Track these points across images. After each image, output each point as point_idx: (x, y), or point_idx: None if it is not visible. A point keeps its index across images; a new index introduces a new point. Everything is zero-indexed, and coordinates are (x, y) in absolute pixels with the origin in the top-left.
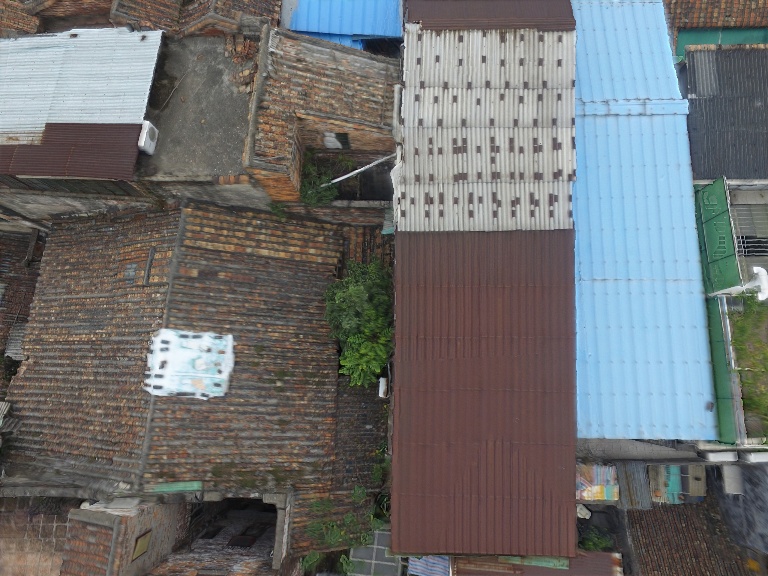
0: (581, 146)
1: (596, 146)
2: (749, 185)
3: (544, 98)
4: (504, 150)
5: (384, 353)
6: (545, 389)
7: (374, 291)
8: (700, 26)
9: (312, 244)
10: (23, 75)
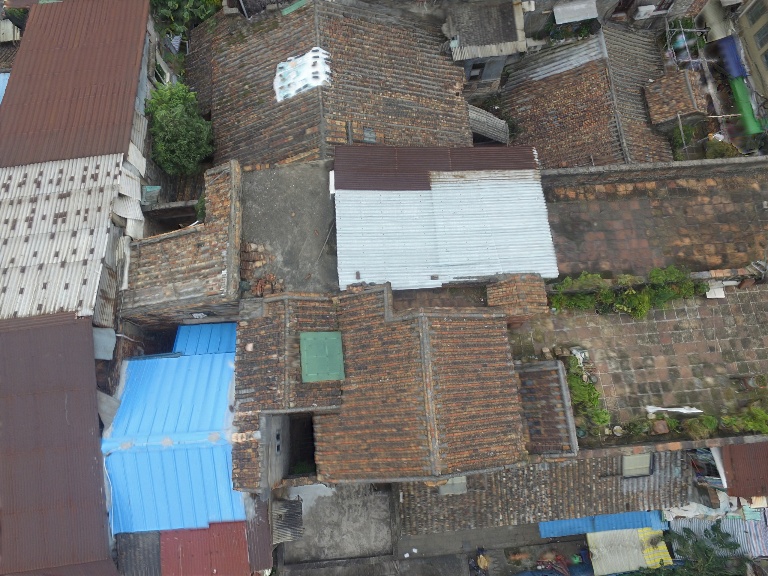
0: None
1: None
2: None
3: None
4: (22, 220)
5: (151, 92)
6: (30, 77)
7: None
8: None
9: None
10: (474, 237)
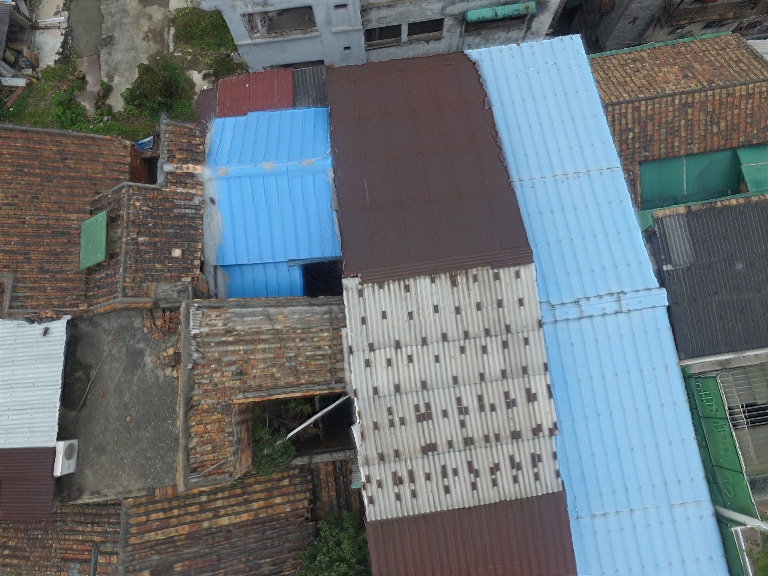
0: (557, 358)
1: (573, 356)
2: (742, 356)
3: (510, 345)
4: (473, 410)
5: None
6: None
7: (351, 573)
8: (662, 157)
9: (277, 491)
10: None
